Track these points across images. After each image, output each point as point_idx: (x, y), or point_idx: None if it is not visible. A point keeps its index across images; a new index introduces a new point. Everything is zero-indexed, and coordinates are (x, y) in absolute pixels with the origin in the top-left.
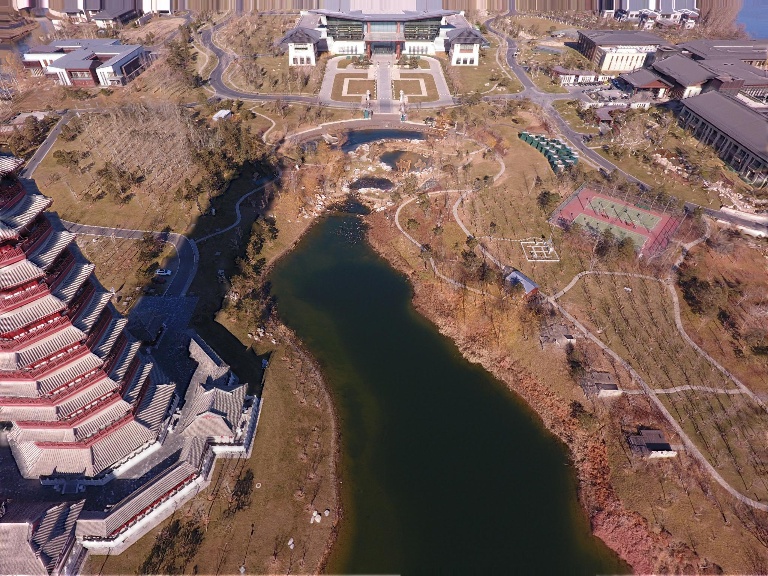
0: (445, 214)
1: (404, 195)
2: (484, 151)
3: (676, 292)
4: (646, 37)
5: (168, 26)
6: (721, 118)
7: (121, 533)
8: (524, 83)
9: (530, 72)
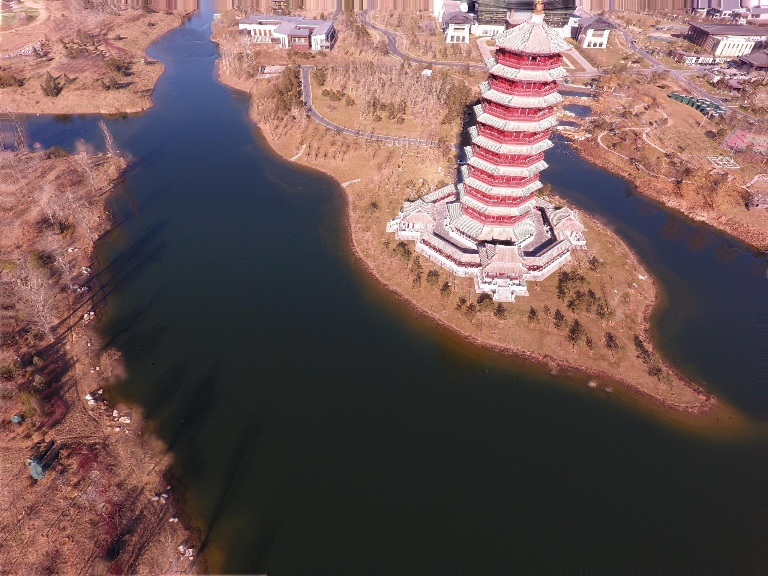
0: (640, 140)
1: None
2: (644, 106)
3: None
4: (752, 29)
5: (325, 9)
6: None
7: (543, 269)
8: (652, 62)
9: (653, 54)
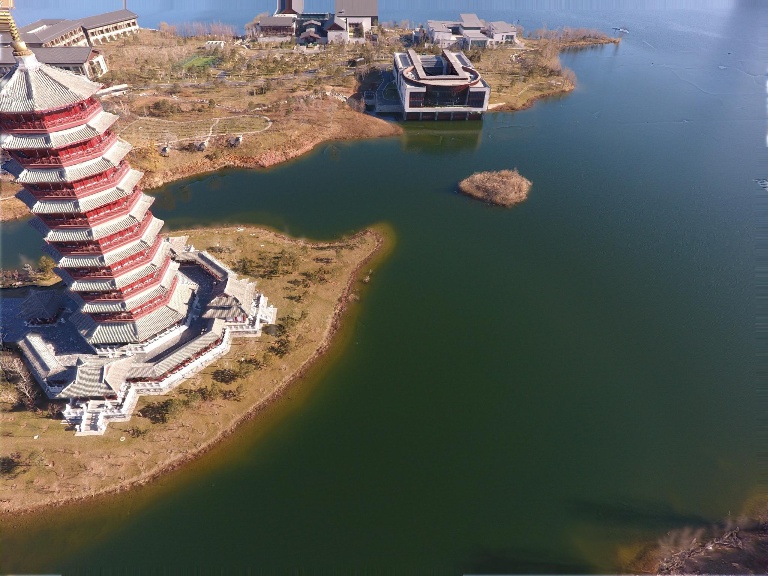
0: None
1: None
2: None
3: (152, 118)
4: None
5: None
6: (8, 58)
7: None
8: None
9: None
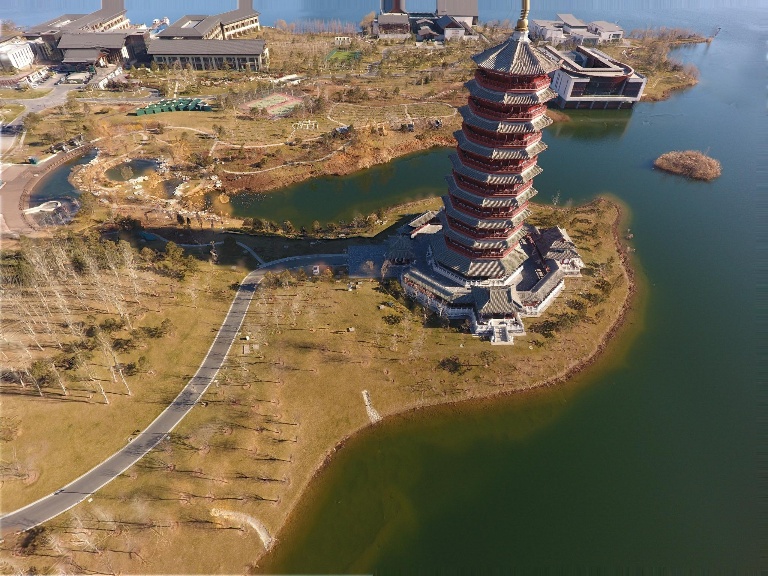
0: None
1: (203, 171)
2: (146, 133)
3: (346, 103)
4: None
5: None
6: (192, 49)
7: None
8: None
9: None
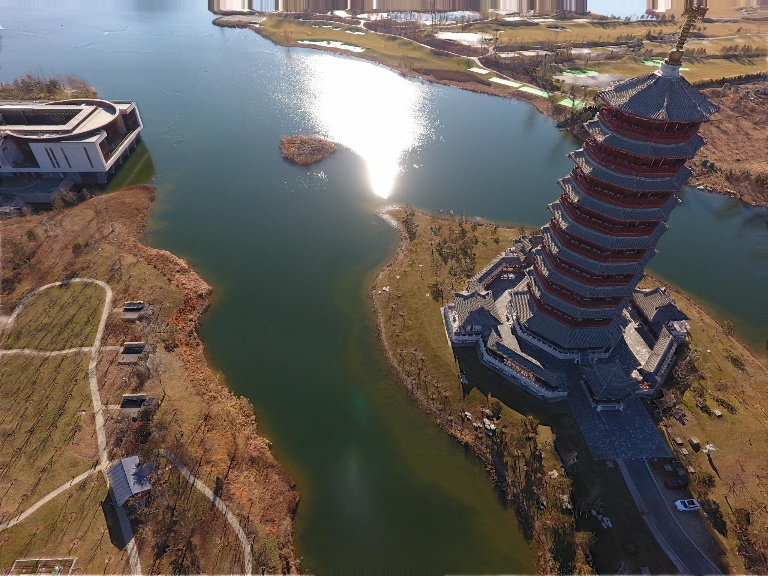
0: None
1: None
2: None
3: None
4: None
5: None
6: None
7: None
8: None
9: None
